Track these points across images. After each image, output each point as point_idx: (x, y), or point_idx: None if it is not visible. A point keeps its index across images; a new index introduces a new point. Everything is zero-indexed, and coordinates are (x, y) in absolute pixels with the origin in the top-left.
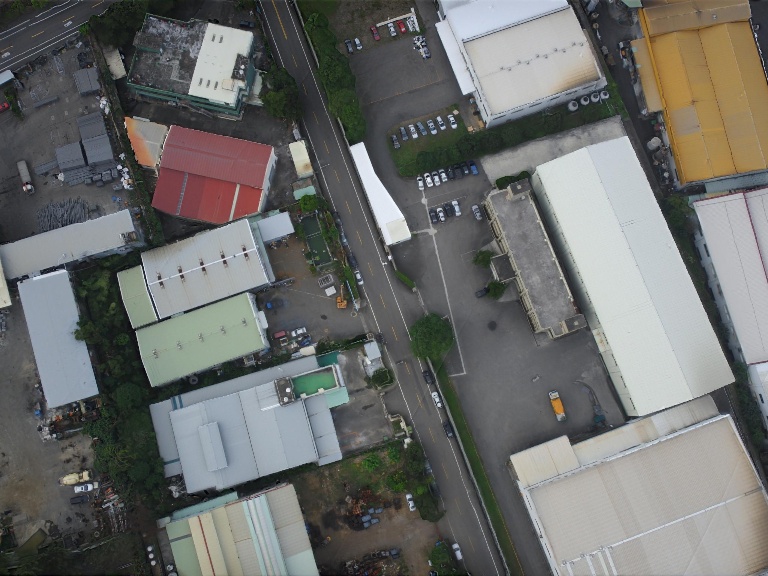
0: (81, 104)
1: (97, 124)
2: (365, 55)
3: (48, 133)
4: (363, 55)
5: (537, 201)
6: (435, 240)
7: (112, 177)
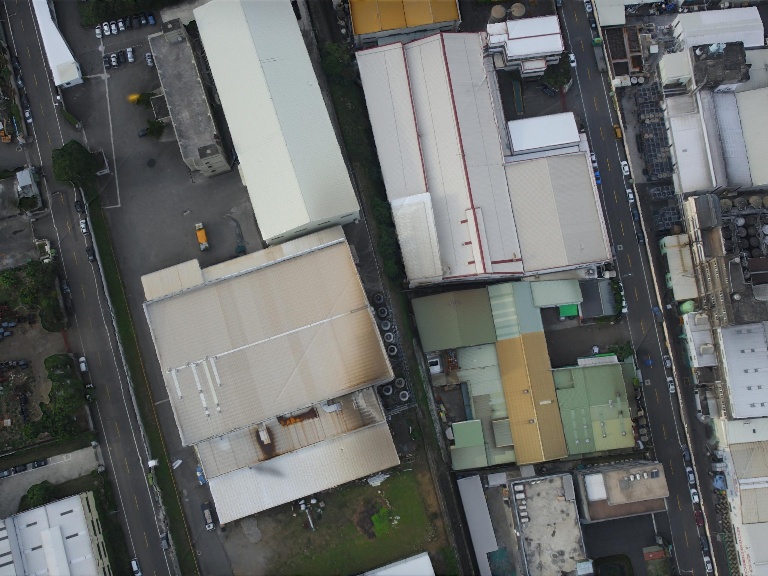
0: None
1: None
2: None
3: None
4: None
5: None
6: (107, 84)
7: None
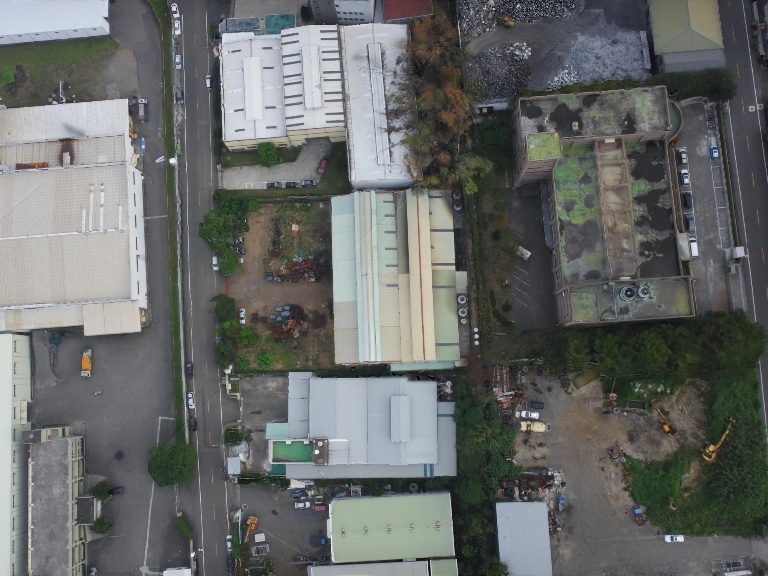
0: None
1: None
2: None
3: None
4: None
5: None
6: (145, 560)
7: None
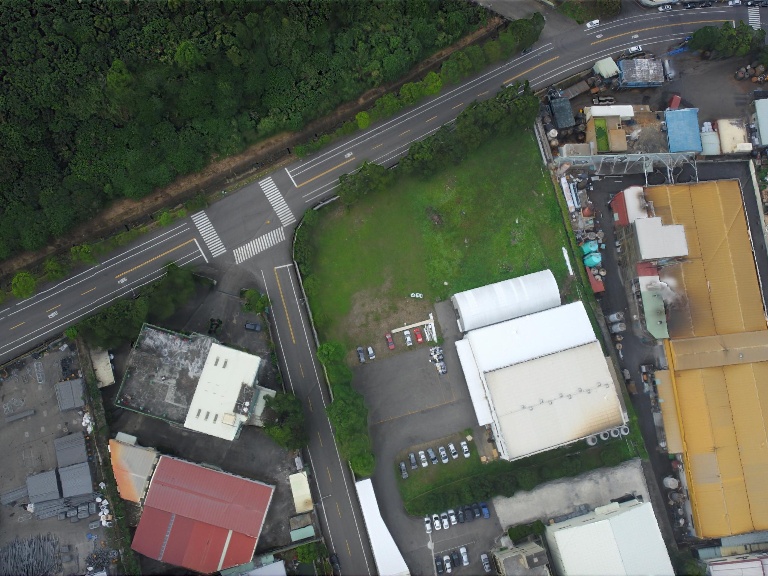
0: (61, 419)
1: (77, 448)
2: (377, 365)
3: (20, 453)
4: (375, 365)
5: (550, 553)
6: None
7: (89, 514)
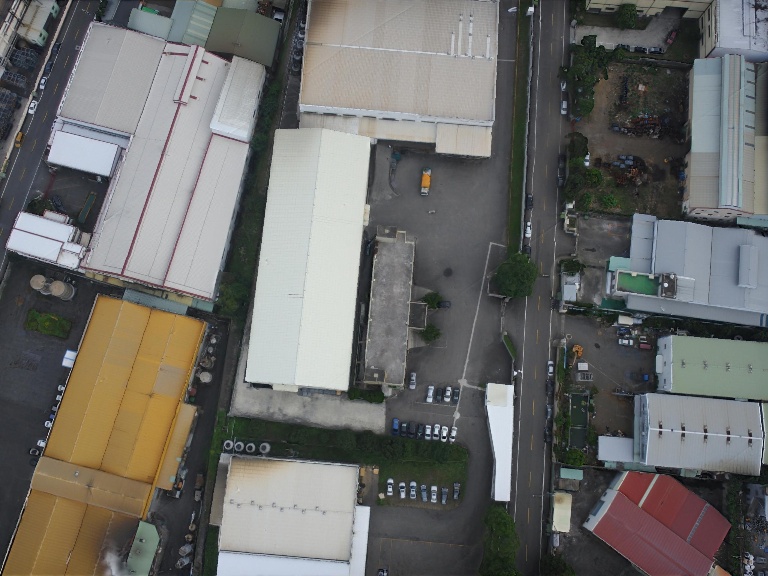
0: None
1: None
2: None
3: None
4: None
5: (352, 366)
6: (464, 373)
7: (765, 573)
